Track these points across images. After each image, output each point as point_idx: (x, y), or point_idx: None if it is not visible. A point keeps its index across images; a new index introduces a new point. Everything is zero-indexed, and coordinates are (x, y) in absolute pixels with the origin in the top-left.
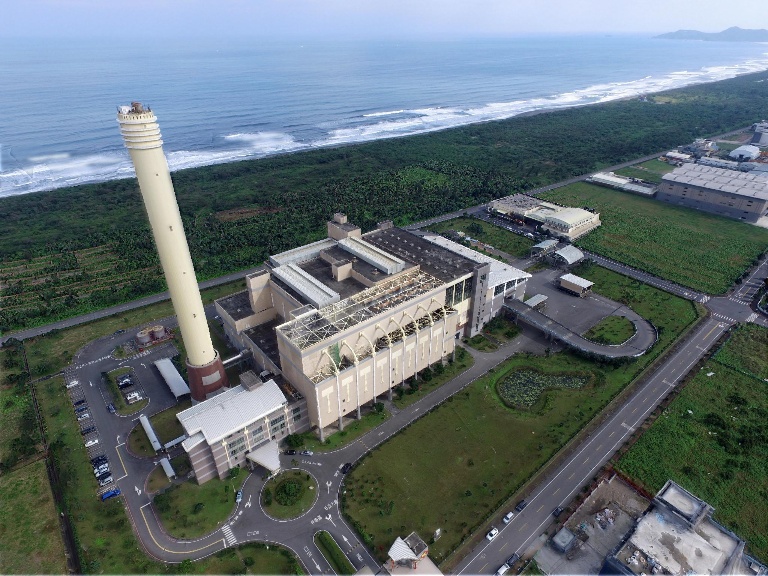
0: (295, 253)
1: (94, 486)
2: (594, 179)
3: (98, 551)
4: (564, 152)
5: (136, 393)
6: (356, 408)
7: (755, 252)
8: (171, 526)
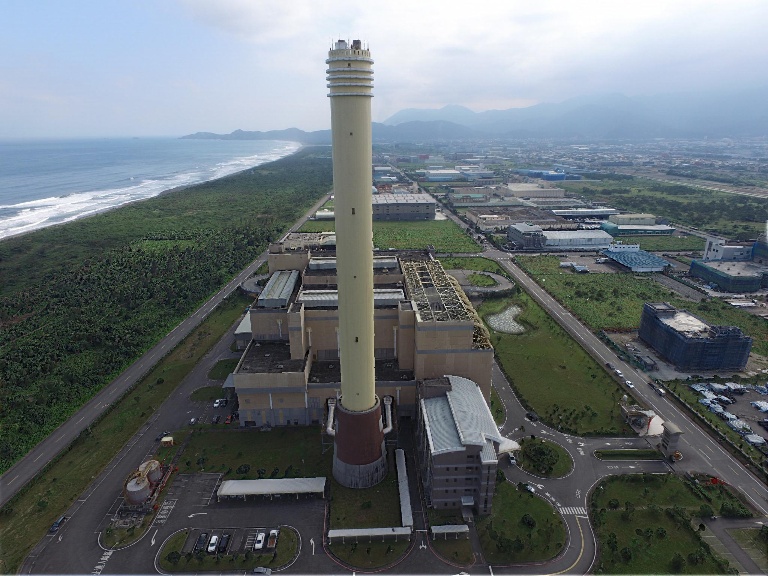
0: (275, 289)
1: None
2: (318, 216)
3: None
4: (260, 207)
5: (259, 534)
6: None
7: (460, 230)
8: (540, 553)
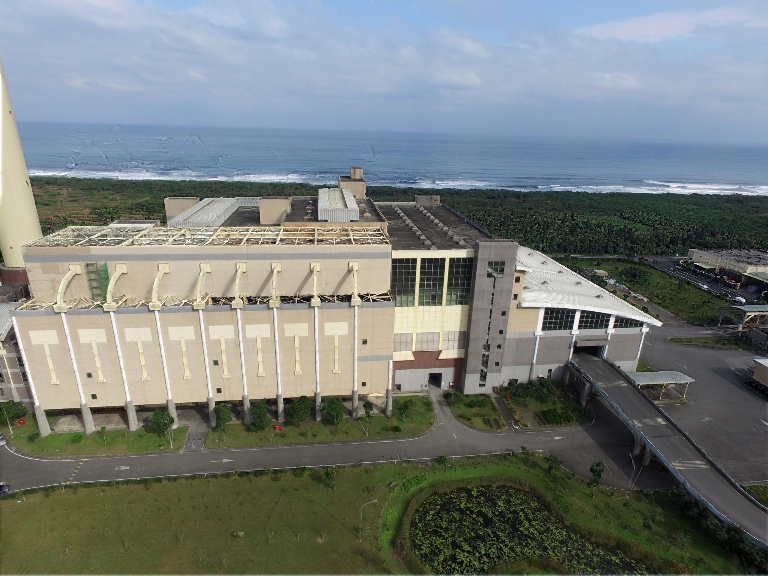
0: None
1: None
2: None
3: None
4: None
5: None
6: (125, 405)
7: None
8: None
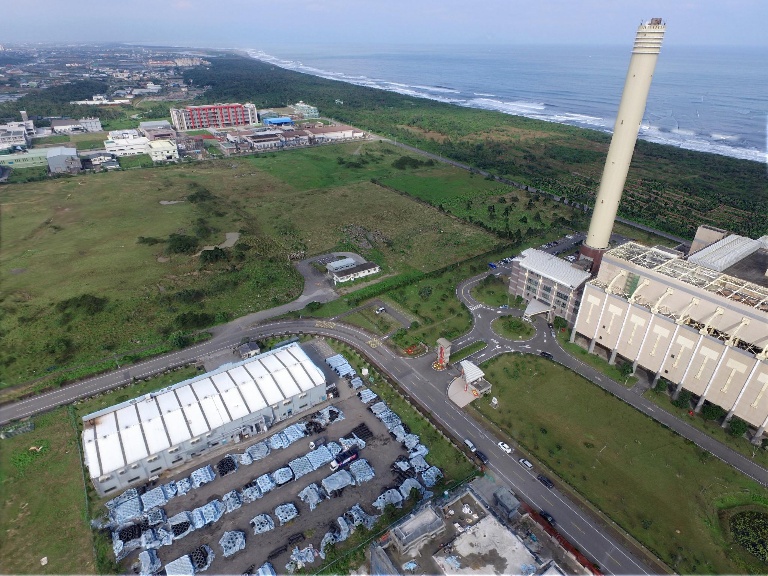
0: None
1: (497, 260)
2: None
3: None
4: None
5: (574, 257)
6: (613, 349)
7: None
8: (478, 287)
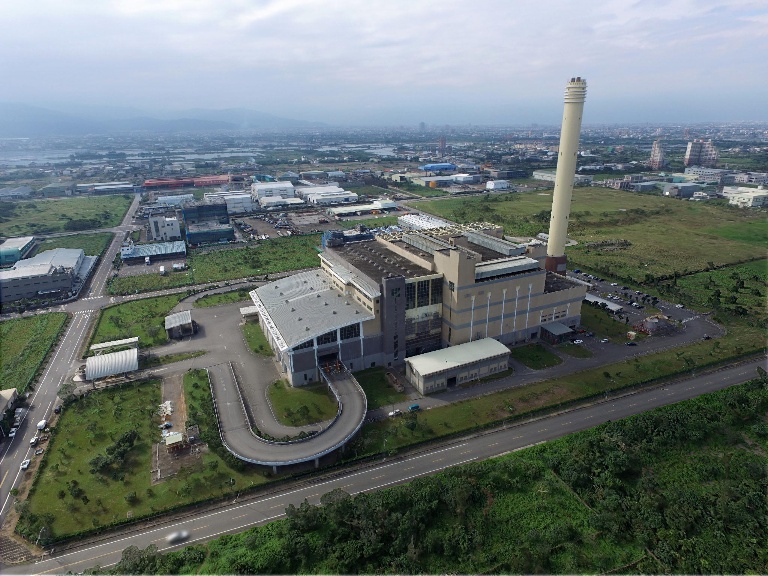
0: None
1: None
2: None
3: None
4: None
5: (615, 298)
6: None
7: None
8: None
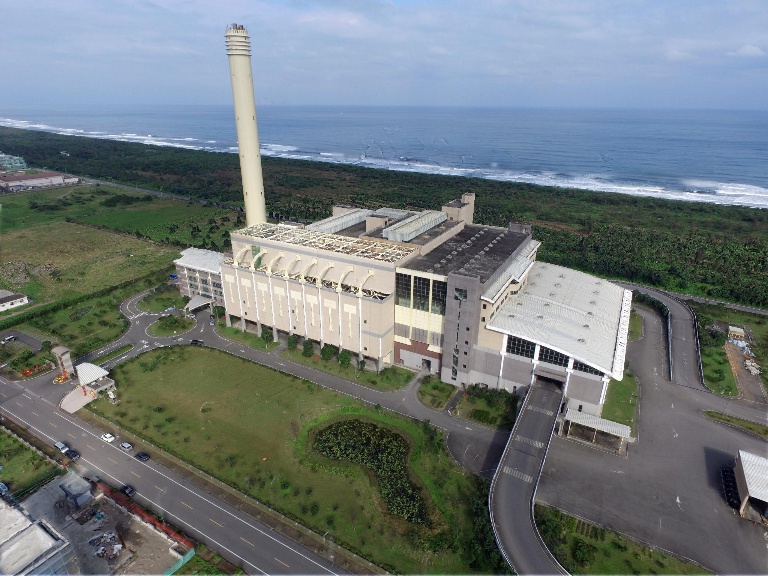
0: (402, 212)
1: None
2: None
3: (133, 285)
4: None
5: None
6: None
7: None
8: None
